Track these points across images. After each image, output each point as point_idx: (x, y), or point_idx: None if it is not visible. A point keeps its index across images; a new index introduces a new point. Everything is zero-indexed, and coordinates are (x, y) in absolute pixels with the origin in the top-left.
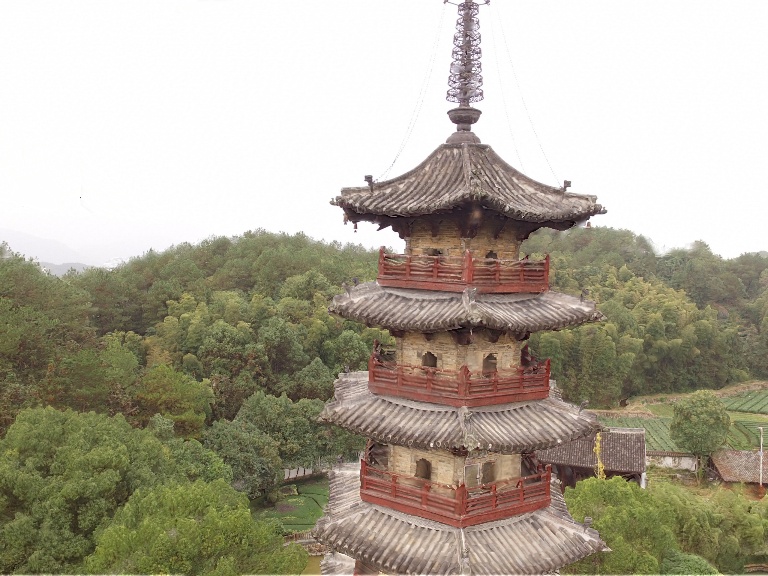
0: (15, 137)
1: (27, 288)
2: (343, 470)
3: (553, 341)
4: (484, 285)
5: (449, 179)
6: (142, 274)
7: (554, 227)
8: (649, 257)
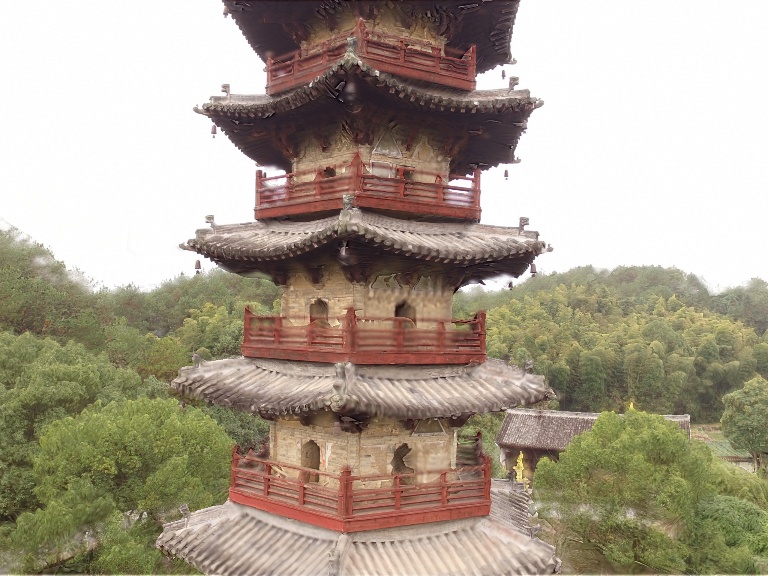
0: (70, 187)
1: (44, 272)
2: None
3: (593, 358)
4: None
5: None
6: (172, 294)
7: None
8: (701, 292)
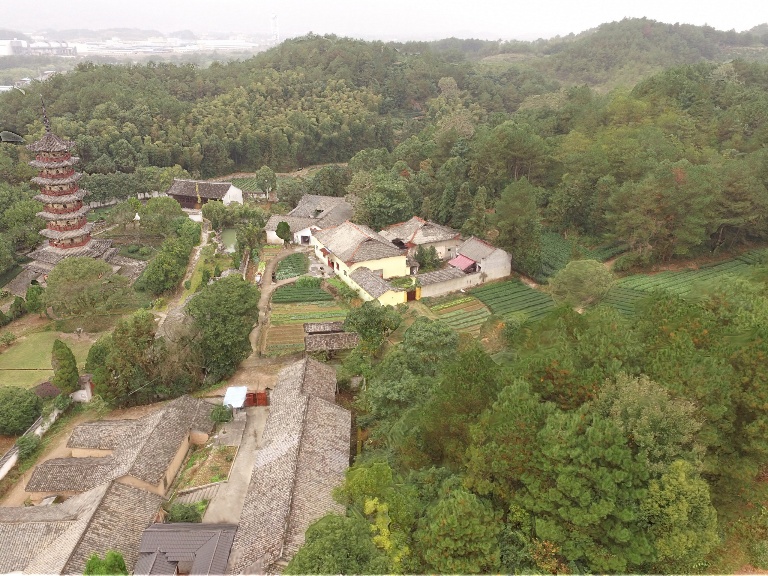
0: None
1: None
2: None
3: (252, 138)
4: (50, 161)
5: None
6: (11, 104)
7: None
8: (378, 67)
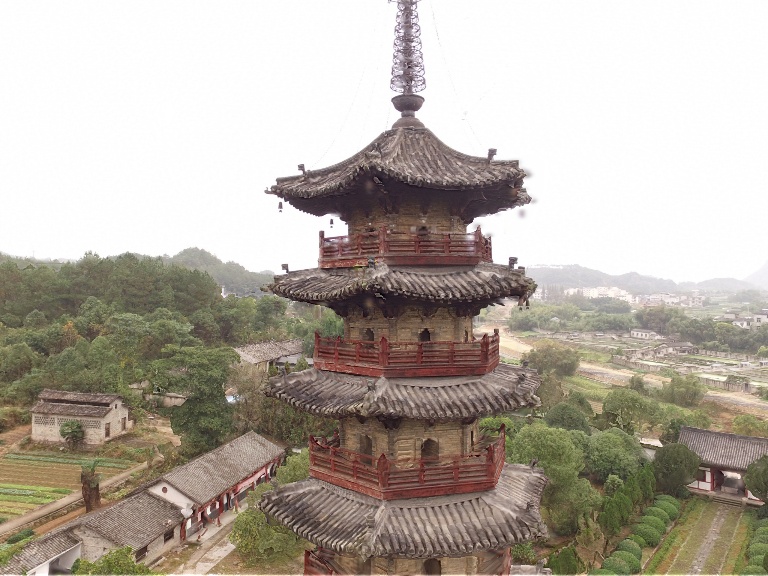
0: None
1: None
2: None
3: None
4: None
5: None
6: None
7: (322, 211)
8: None
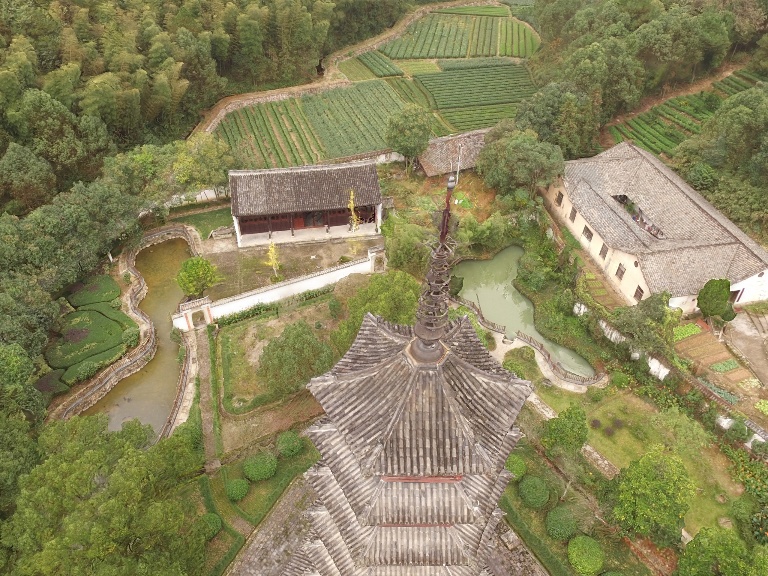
0: None
1: None
2: (318, 512)
3: (251, 23)
4: None
5: (436, 408)
6: None
7: None
8: None
